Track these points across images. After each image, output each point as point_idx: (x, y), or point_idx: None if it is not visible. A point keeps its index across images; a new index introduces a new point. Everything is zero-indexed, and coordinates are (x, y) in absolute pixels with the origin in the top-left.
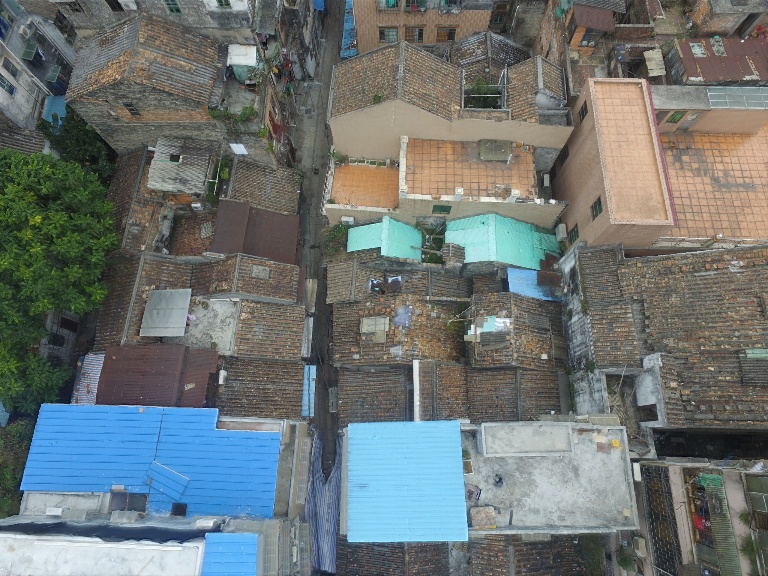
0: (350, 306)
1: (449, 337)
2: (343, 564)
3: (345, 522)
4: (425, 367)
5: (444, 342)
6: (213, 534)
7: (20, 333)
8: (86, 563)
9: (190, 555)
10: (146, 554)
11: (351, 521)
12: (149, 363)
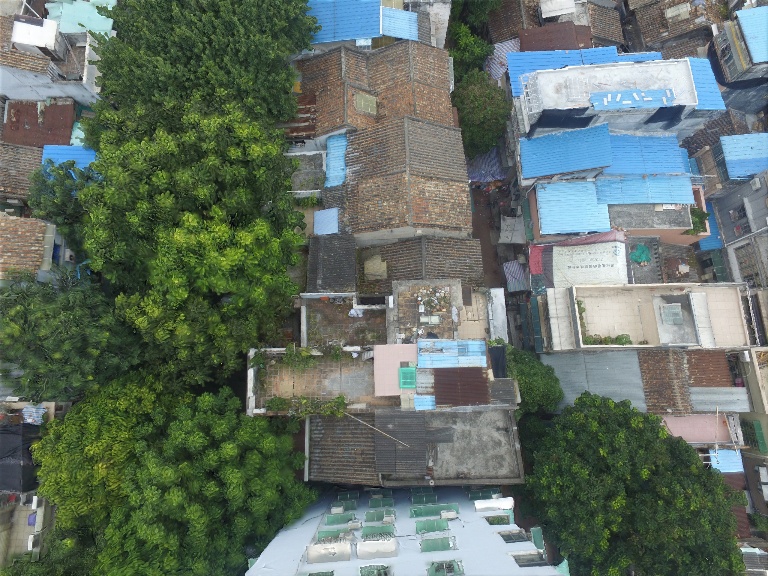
0: (651, 7)
1: (723, 18)
2: (685, 147)
3: (740, 65)
4: (723, 26)
5: (722, 20)
6: (689, 58)
7: (493, 5)
8: (627, 75)
9: (681, 66)
10: (658, 68)
11: (753, 54)
12: (552, 34)
